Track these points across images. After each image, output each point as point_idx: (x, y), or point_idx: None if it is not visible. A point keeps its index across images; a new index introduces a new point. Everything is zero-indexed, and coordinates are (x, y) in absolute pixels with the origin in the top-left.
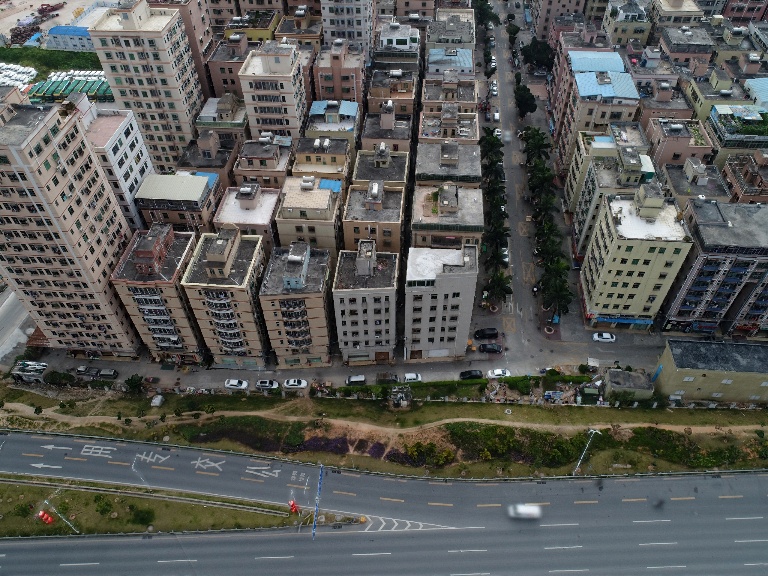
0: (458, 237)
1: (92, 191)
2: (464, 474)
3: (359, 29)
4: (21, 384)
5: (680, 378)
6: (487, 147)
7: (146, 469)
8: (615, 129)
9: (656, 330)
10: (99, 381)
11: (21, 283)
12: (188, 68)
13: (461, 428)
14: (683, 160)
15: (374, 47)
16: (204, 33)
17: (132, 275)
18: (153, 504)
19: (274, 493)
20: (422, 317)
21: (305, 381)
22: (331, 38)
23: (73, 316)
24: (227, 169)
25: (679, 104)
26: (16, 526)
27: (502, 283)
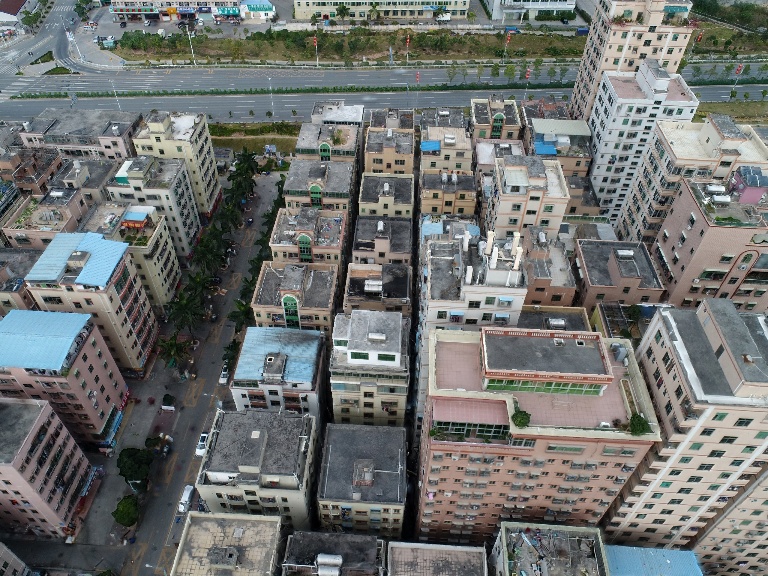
0: None
1: None
2: None
3: None
4: None
5: None
6: None
7: None
8: (110, 231)
9: None
10: None
11: None
12: None
13: None
14: None
15: None
16: None
17: None
18: None
19: None
20: None
21: None
22: None
23: None
24: None
25: None
26: None
27: None
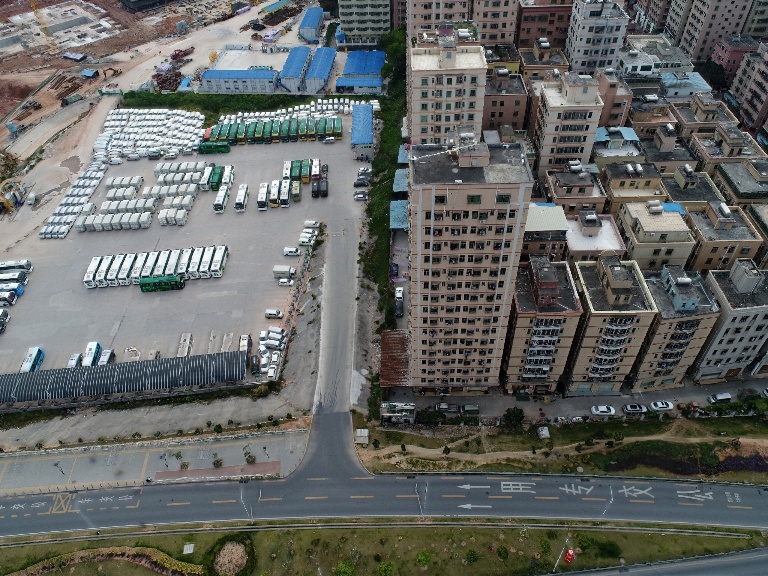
0: None
1: None
2: None
3: (611, 58)
4: (388, 426)
5: None
6: None
7: (578, 502)
8: None
9: None
10: (464, 417)
11: (426, 322)
12: None
13: None
14: None
15: None
16: None
17: (531, 307)
18: (610, 536)
19: (721, 516)
20: None
21: (670, 403)
22: (580, 68)
23: (458, 352)
24: None
25: None
26: (486, 570)
27: None
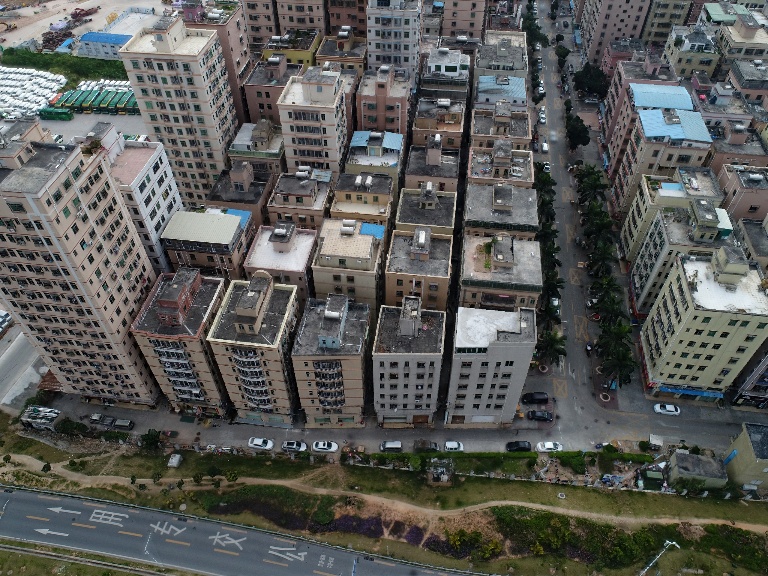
0: (512, 296)
1: (115, 235)
2: (512, 570)
3: (406, 54)
4: (31, 431)
5: (759, 469)
6: (538, 185)
7: (159, 543)
8: (684, 175)
9: (725, 403)
10: (113, 432)
11: (34, 329)
12: (223, 92)
13: (509, 513)
14: (760, 213)
15: (419, 70)
16: (241, 54)
17: (154, 325)
18: None
19: None
20: (469, 383)
21: (336, 444)
22: (375, 62)
23: (89, 364)
24: (260, 205)
25: (754, 148)
26: None
27: (556, 344)
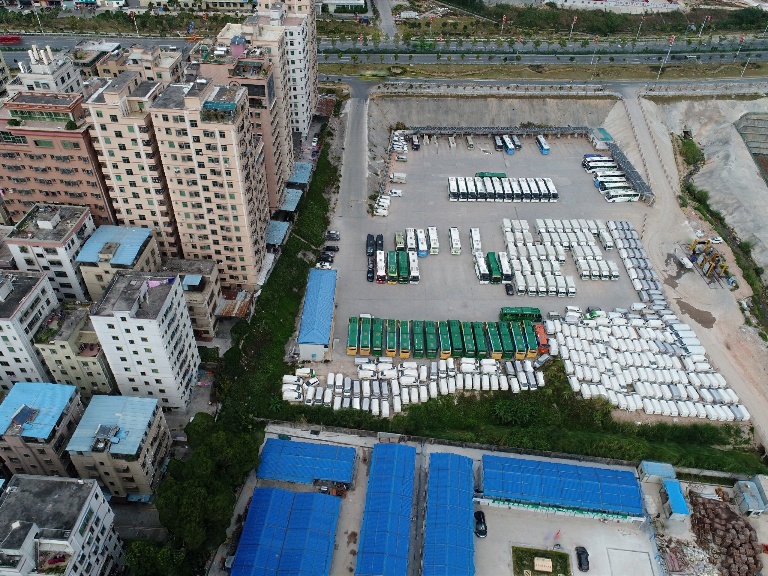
0: None
1: None
2: None
3: None
4: None
5: None
6: None
7: None
8: None
9: None
10: None
11: None
12: None
13: None
14: None
15: None
16: None
17: None
18: None
19: None
20: None
21: None
22: None
23: None
24: None
25: None
26: None
27: None
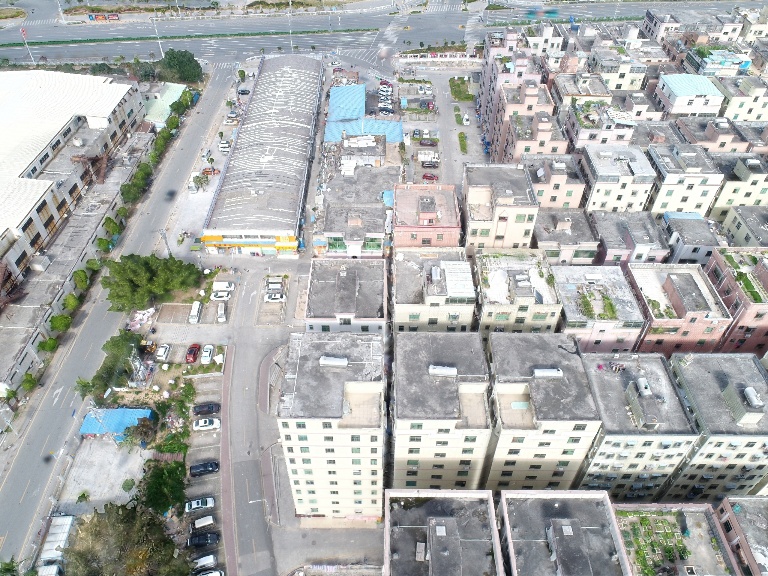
0: None
1: None
2: None
3: None
4: None
5: None
6: None
7: None
8: None
9: None
10: None
11: None
12: None
13: None
14: None
15: None
16: None
17: None
18: None
19: None
20: None
21: None
22: None
23: None
24: None
25: None
26: None
27: None
